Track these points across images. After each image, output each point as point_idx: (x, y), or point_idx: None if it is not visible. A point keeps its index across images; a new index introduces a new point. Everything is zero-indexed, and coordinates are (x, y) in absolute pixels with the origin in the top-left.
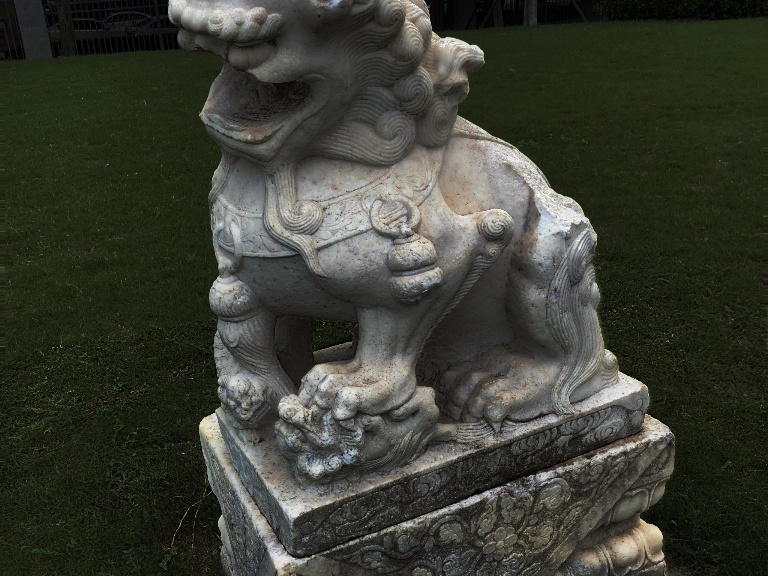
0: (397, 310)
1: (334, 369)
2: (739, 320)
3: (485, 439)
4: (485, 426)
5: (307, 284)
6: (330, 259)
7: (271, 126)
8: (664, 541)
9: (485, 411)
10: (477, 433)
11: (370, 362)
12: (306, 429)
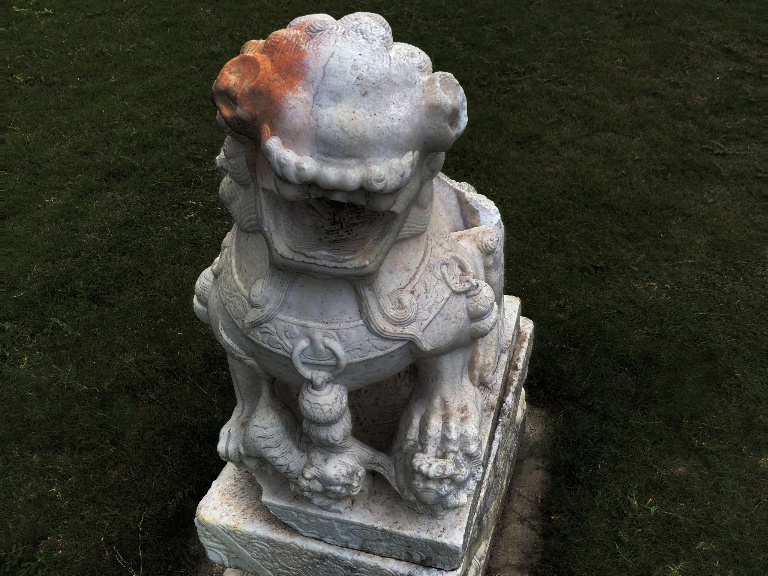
0: (468, 345)
1: (439, 416)
2: None
3: (490, 399)
4: (483, 389)
5: (404, 360)
6: (434, 333)
7: (374, 243)
8: None
9: (482, 379)
10: (484, 398)
11: (451, 394)
12: (455, 475)
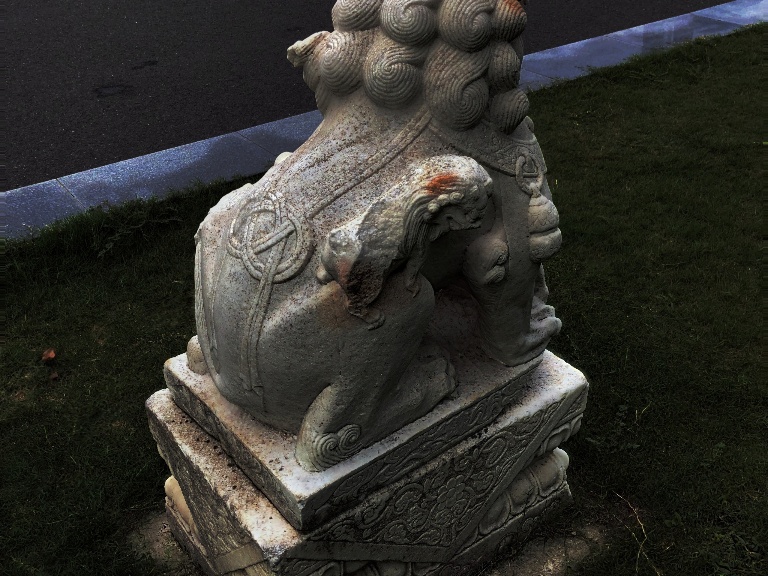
0: None
1: None
2: None
3: None
4: None
5: None
6: None
7: None
8: (148, 572)
9: None
10: None
11: None
12: None
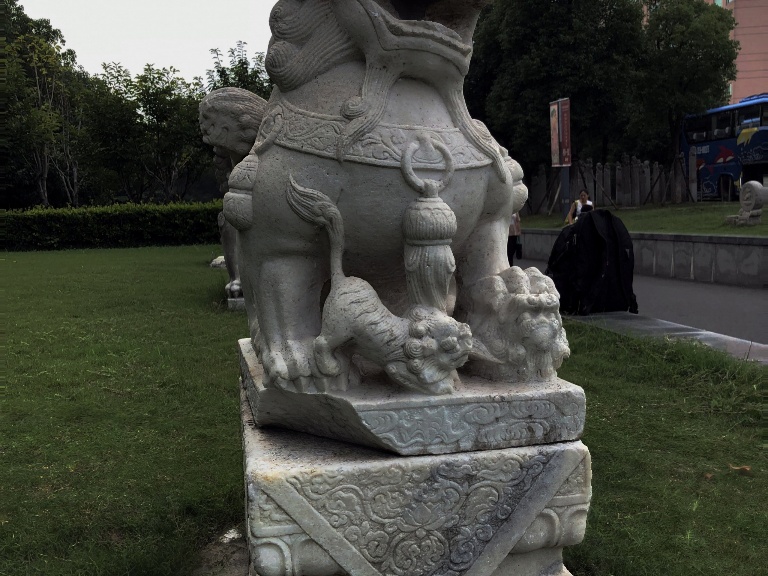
0: (508, 219)
1: None
2: (153, 412)
3: None
4: None
5: (482, 197)
6: (503, 167)
7: None
8: None
9: None
10: None
11: None
12: None
